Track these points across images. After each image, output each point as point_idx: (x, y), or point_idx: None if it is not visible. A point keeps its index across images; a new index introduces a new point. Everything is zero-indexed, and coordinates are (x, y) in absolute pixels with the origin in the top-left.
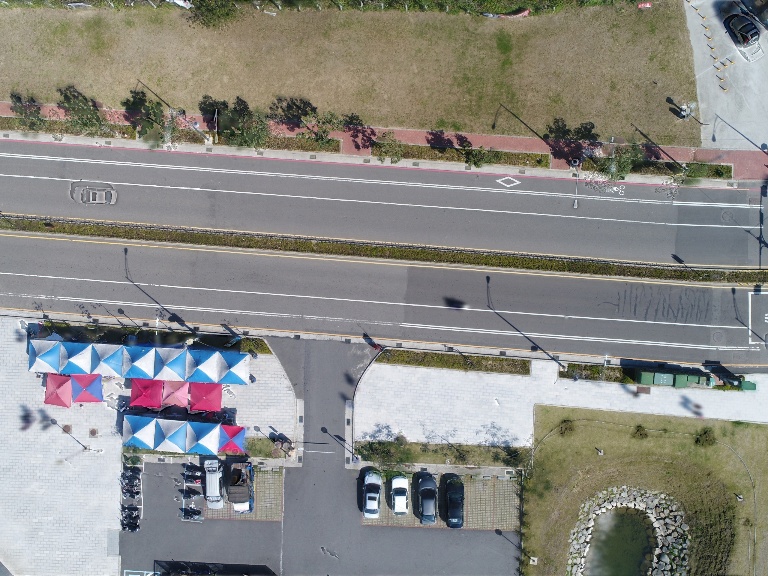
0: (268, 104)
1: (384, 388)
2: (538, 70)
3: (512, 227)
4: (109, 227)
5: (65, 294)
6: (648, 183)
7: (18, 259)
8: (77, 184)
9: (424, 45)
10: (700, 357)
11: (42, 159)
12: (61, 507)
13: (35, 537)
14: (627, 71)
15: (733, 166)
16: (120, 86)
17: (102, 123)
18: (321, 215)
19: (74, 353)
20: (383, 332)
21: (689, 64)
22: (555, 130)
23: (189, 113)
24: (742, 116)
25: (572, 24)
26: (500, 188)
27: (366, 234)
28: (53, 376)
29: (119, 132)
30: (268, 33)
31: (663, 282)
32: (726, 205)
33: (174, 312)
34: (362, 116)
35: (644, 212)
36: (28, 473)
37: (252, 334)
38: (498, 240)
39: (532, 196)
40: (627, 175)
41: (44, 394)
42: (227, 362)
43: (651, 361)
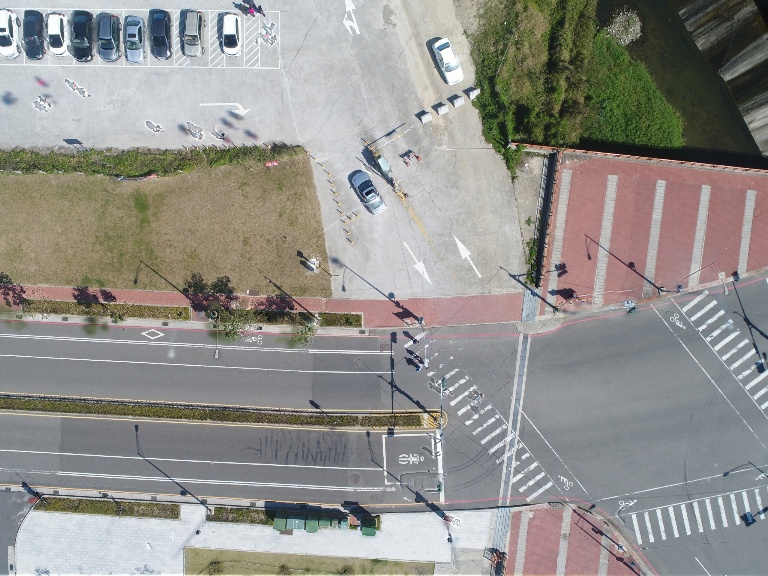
0: None
1: (42, 535)
2: (174, 227)
3: (157, 378)
4: None
5: None
6: (284, 332)
7: None
8: None
9: (66, 206)
10: (339, 498)
11: None
12: None
13: None
14: (258, 227)
15: (363, 315)
16: None
17: None
18: None
19: None
20: (41, 480)
21: (317, 219)
22: (193, 284)
23: None
24: (369, 267)
25: (204, 183)
26: (145, 340)
27: (20, 387)
28: None
29: None
30: None
31: (301, 427)
32: (358, 352)
33: None
34: (11, 275)
35: (281, 360)
36: None
37: None
38: (144, 390)
39: (175, 347)
40: (264, 325)
41: None
42: None
43: (294, 503)
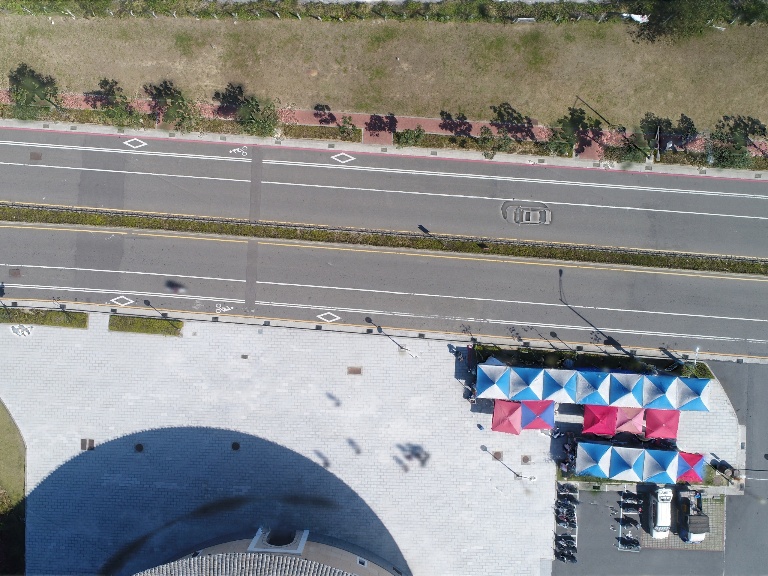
0: (714, 121)
1: None
2: None
3: None
4: (546, 248)
5: (495, 317)
6: None
7: (446, 281)
8: (509, 203)
9: None
10: None
11: (472, 178)
12: (491, 536)
13: (463, 567)
14: None
15: None
16: (558, 103)
17: (537, 141)
18: (767, 236)
19: (530, 379)
20: None
21: None
22: None
23: (629, 130)
24: None
25: None
26: None
27: None
28: (502, 402)
29: (555, 150)
30: (716, 48)
31: None
32: None
33: (610, 335)
34: None
35: None
36: (456, 501)
37: (692, 358)
38: None
39: None
40: None
41: (473, 420)
42: (691, 388)
43: None
